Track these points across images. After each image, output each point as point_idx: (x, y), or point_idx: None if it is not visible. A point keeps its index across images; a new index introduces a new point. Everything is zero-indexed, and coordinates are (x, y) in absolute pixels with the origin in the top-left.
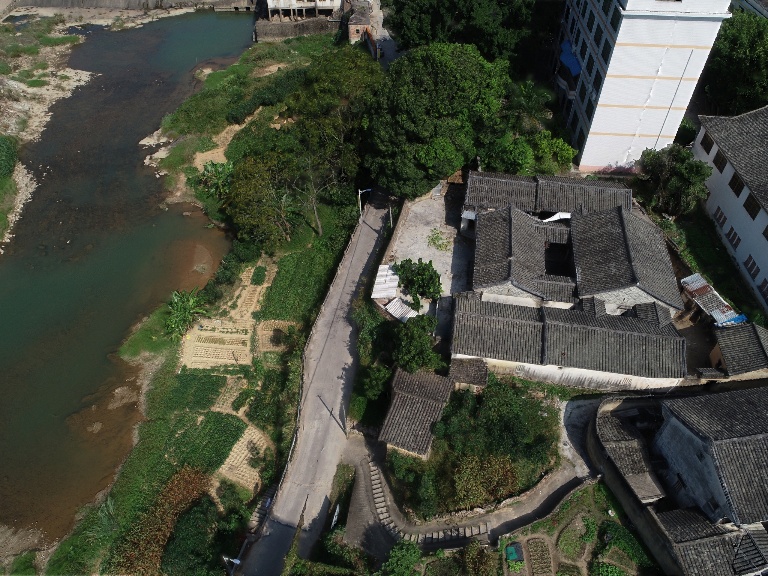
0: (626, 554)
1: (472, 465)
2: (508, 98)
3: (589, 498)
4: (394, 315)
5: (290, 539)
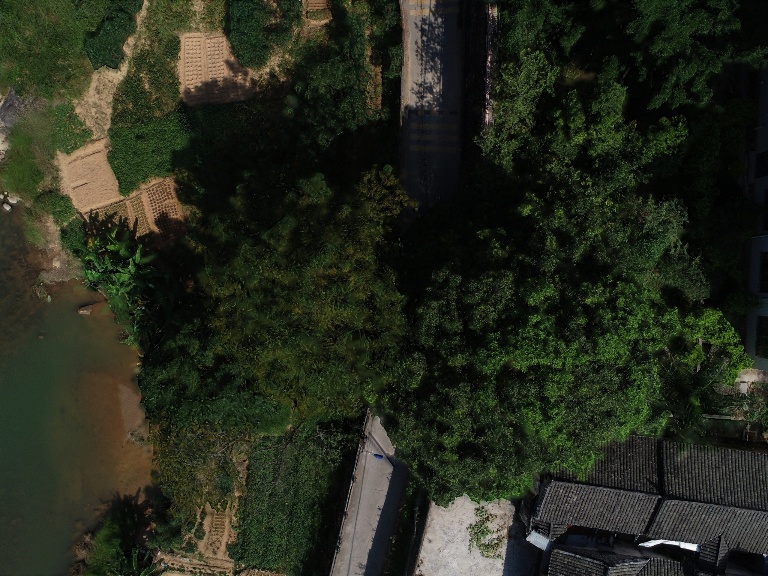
0: None
1: None
2: (660, 391)
3: None
4: None
5: None
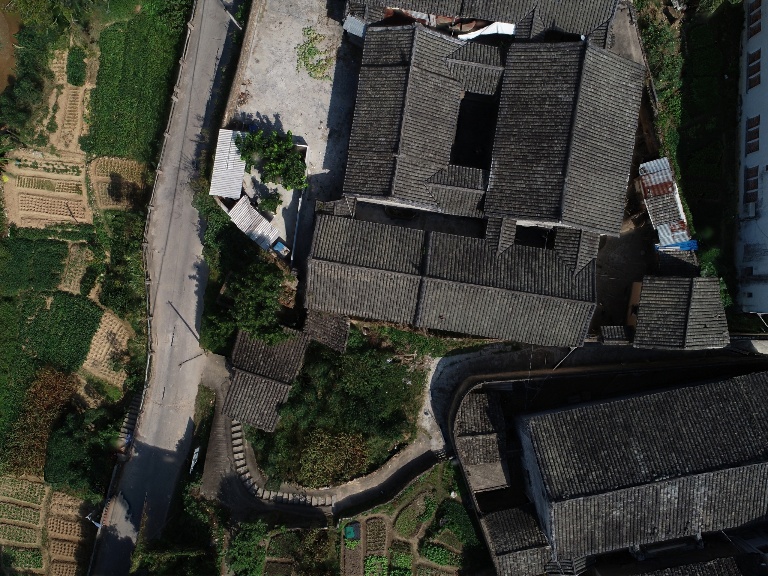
0: (456, 536)
1: (321, 443)
2: None
3: (437, 475)
4: (240, 228)
5: (159, 460)
